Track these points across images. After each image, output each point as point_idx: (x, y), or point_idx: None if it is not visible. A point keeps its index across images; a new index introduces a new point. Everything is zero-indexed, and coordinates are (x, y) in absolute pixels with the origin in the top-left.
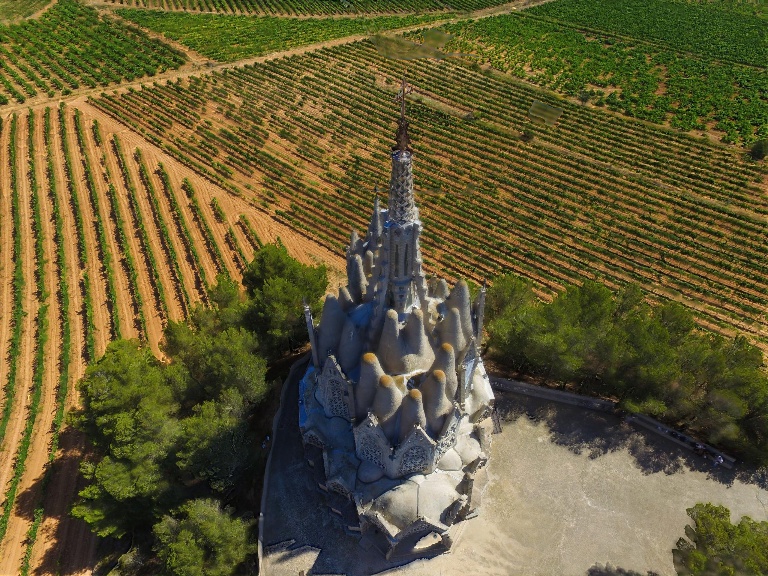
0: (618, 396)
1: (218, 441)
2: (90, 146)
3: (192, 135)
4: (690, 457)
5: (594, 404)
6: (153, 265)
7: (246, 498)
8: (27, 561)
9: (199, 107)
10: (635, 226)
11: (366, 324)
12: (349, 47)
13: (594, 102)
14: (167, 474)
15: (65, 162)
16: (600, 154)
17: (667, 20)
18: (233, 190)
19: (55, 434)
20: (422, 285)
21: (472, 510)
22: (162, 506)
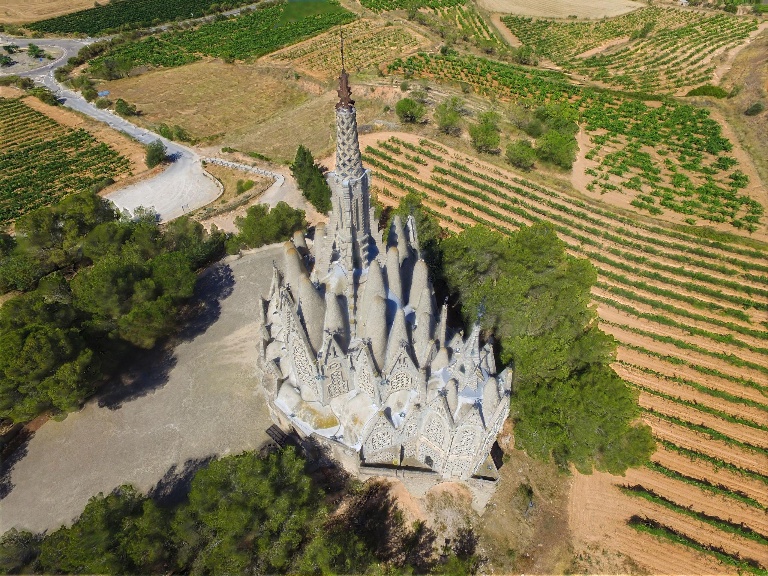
0: None
1: (431, 245)
2: None
3: None
4: None
5: None
6: None
7: None
8: None
9: None
10: None
11: None
12: None
13: None
14: None
15: None
16: None
17: None
18: None
19: None
20: None
21: None
22: None
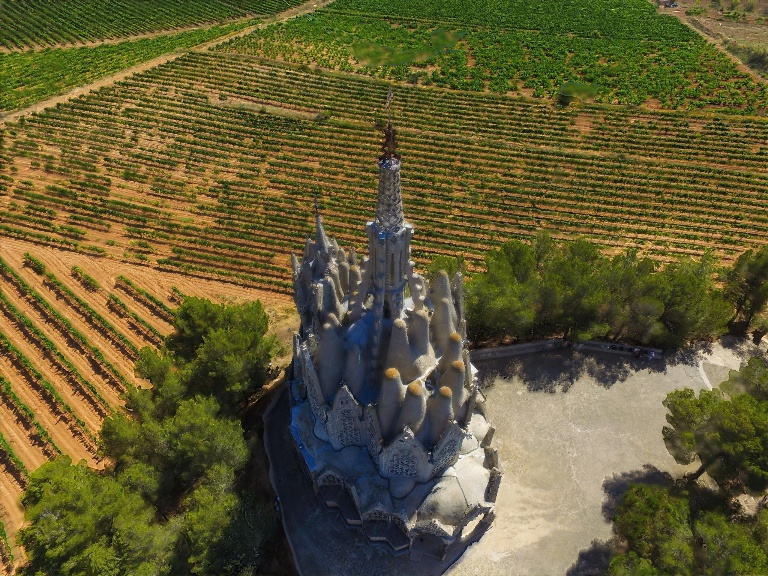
0: (557, 332)
1: (235, 525)
2: None
3: (12, 202)
4: (631, 361)
5: (548, 345)
6: (28, 365)
7: (271, 572)
8: None
9: (6, 167)
10: (502, 184)
11: (366, 342)
12: (163, 69)
13: (424, 82)
14: None
15: None
16: (447, 128)
17: (451, 0)
18: (94, 251)
19: None
20: (416, 286)
21: None
22: None
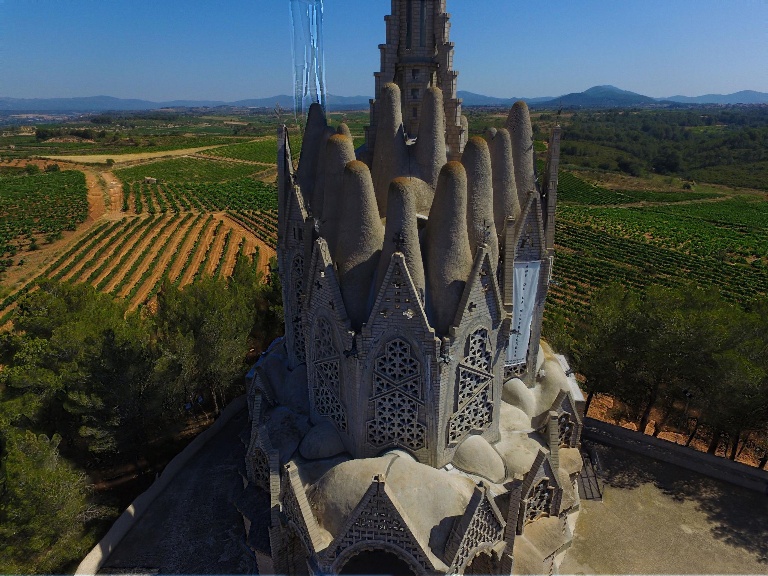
0: None
1: (117, 352)
2: (208, 235)
3: None
4: None
5: None
6: None
7: None
8: None
9: None
10: None
11: None
12: None
13: (734, 259)
14: (46, 420)
15: None
16: None
17: None
18: None
19: None
20: (448, 68)
21: None
22: None
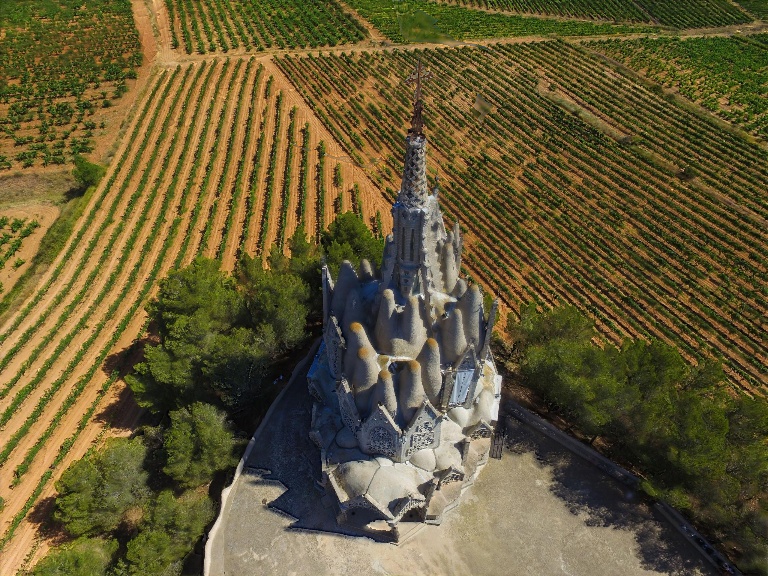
0: None
1: (235, 362)
2: (260, 97)
3: (343, 104)
4: (711, 575)
5: (616, 472)
6: (267, 208)
7: (253, 422)
8: (94, 405)
9: (359, 80)
10: None
11: (373, 298)
12: (524, 47)
13: None
14: (197, 376)
15: (237, 107)
16: None
17: None
18: (358, 160)
19: (148, 319)
20: (426, 275)
21: (434, 517)
22: (184, 399)
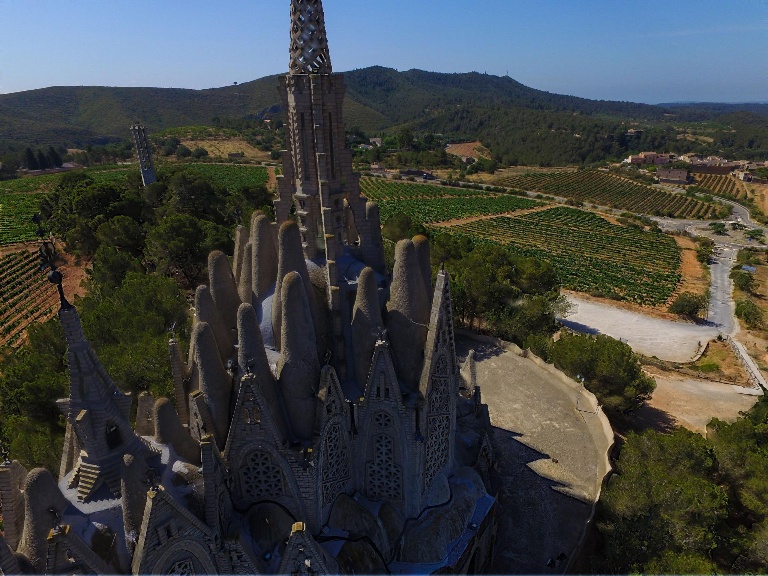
0: None
1: (643, 519)
2: None
3: None
4: None
5: None
6: None
7: None
8: None
9: None
10: None
11: None
12: None
13: None
14: None
15: None
16: None
17: None
18: None
19: None
20: None
21: None
22: None
